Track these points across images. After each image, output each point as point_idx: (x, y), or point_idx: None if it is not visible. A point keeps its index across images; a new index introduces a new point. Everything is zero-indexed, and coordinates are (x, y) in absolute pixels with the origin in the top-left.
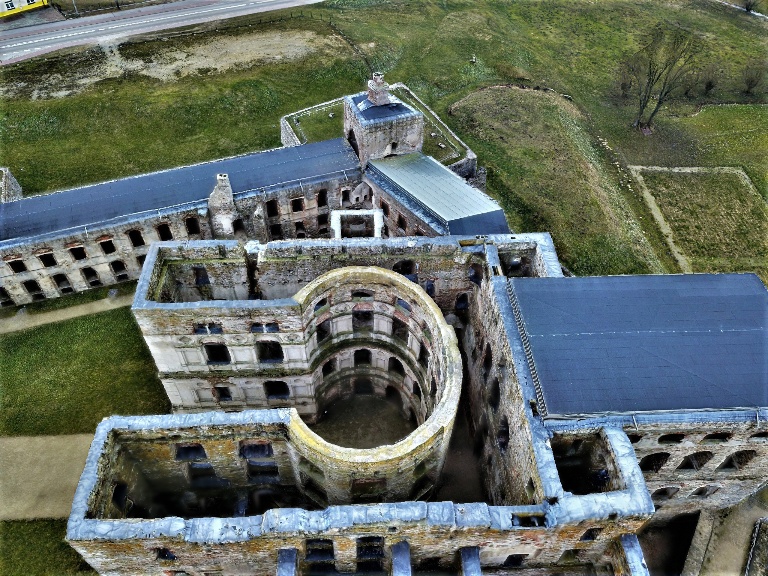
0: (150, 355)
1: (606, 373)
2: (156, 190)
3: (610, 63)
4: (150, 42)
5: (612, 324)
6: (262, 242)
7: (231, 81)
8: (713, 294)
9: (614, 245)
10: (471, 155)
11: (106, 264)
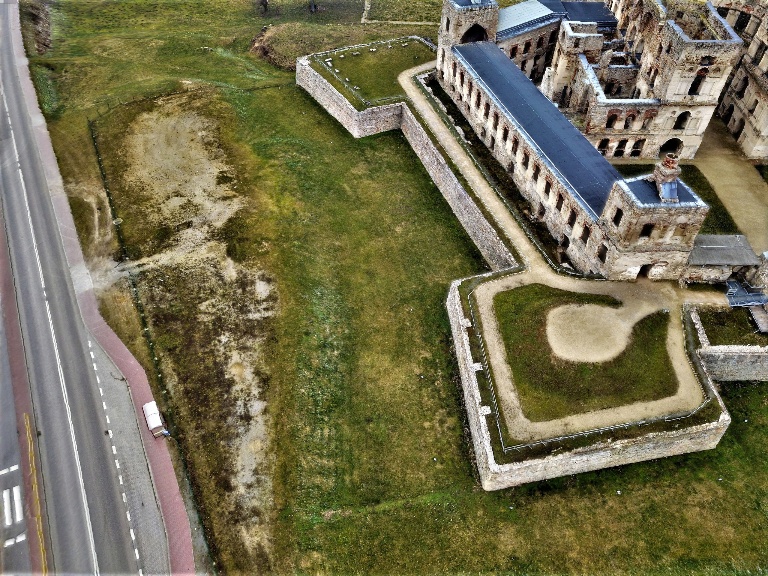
0: None
1: None
2: (545, 119)
3: (209, 7)
4: (123, 233)
5: None
6: None
7: (255, 159)
8: None
9: None
10: (415, 37)
11: None
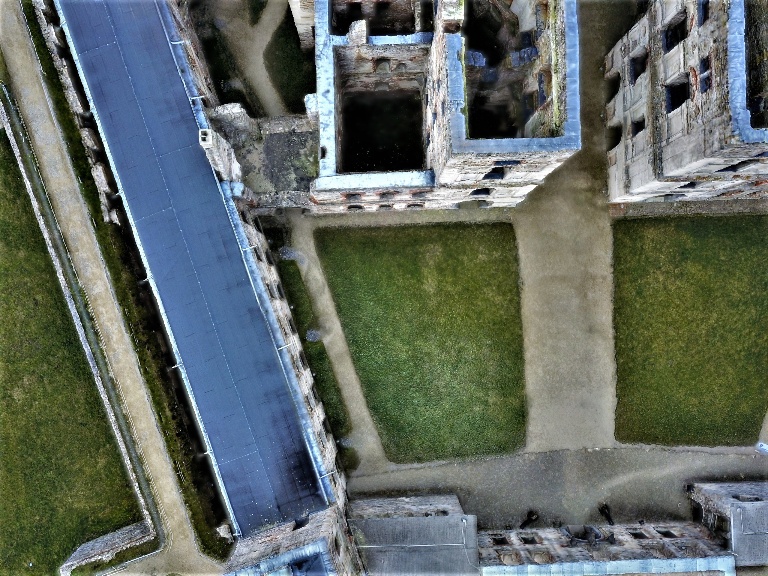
0: (415, 263)
1: None
2: (198, 262)
3: None
4: None
5: None
6: (255, 125)
7: None
8: None
9: None
10: None
11: (293, 338)
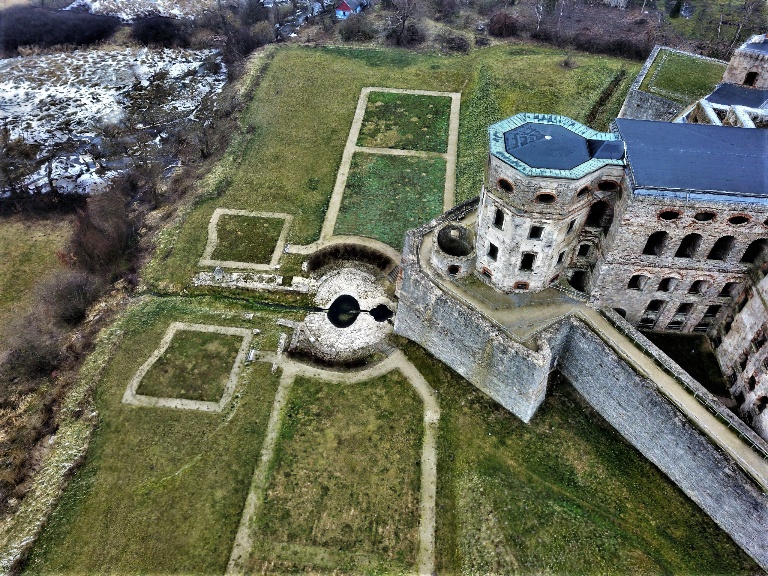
0: None
1: (767, 141)
2: None
3: None
4: None
5: (765, 162)
6: None
7: None
8: (680, 172)
9: (552, 575)
10: None
11: None
